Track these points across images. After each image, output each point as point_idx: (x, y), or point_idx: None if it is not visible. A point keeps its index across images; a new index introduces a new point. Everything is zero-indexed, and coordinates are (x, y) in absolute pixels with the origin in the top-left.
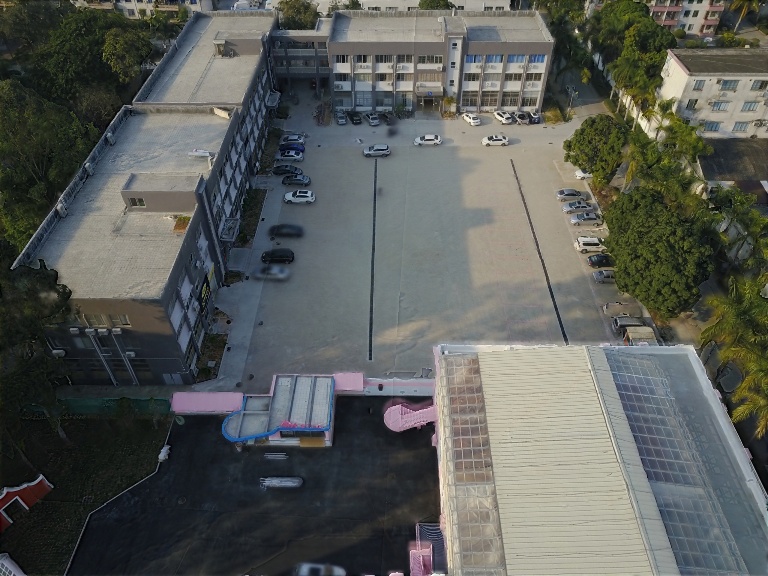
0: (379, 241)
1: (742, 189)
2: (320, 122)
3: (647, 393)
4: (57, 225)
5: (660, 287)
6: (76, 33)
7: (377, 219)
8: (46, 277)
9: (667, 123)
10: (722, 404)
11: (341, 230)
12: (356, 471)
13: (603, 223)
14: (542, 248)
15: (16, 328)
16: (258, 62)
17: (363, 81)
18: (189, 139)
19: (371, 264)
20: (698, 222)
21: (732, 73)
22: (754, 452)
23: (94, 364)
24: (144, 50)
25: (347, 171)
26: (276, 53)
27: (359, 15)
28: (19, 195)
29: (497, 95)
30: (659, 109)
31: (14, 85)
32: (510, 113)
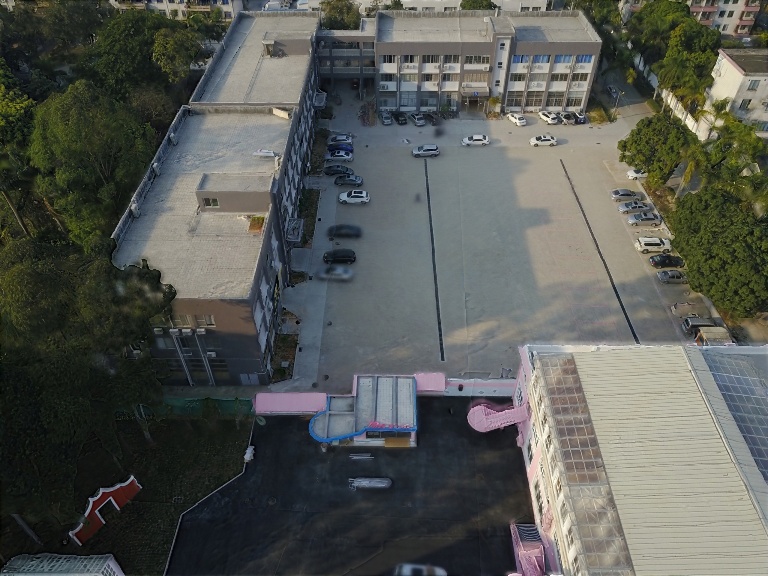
0: (438, 241)
1: None
2: (365, 122)
3: (748, 393)
4: (131, 225)
5: (738, 287)
6: (125, 33)
7: (433, 219)
8: (154, 277)
9: (721, 123)
10: None
11: (399, 230)
12: (444, 472)
13: (661, 223)
14: (602, 248)
15: (131, 328)
16: (309, 62)
17: (409, 81)
18: (251, 139)
19: (433, 264)
20: None
21: None
22: None
23: (172, 364)
24: (193, 50)
25: (398, 171)
26: (321, 53)
27: (402, 15)
28: (86, 195)
29: (542, 95)
30: (713, 109)
31: (88, 85)
32: (555, 113)
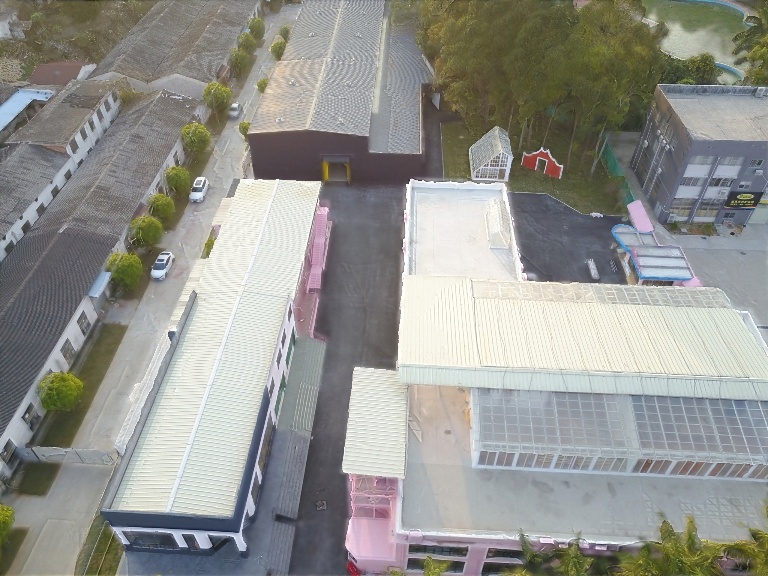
0: None
1: None
2: None
3: (746, 434)
4: (745, 96)
5: None
6: None
7: None
8: (654, 57)
9: None
10: None
11: None
12: None
13: None
14: None
15: (614, 62)
16: None
17: None
18: None
19: None
20: None
21: None
22: None
23: (649, 167)
24: None
25: None
26: None
27: None
28: None
29: None
30: None
31: None
32: None
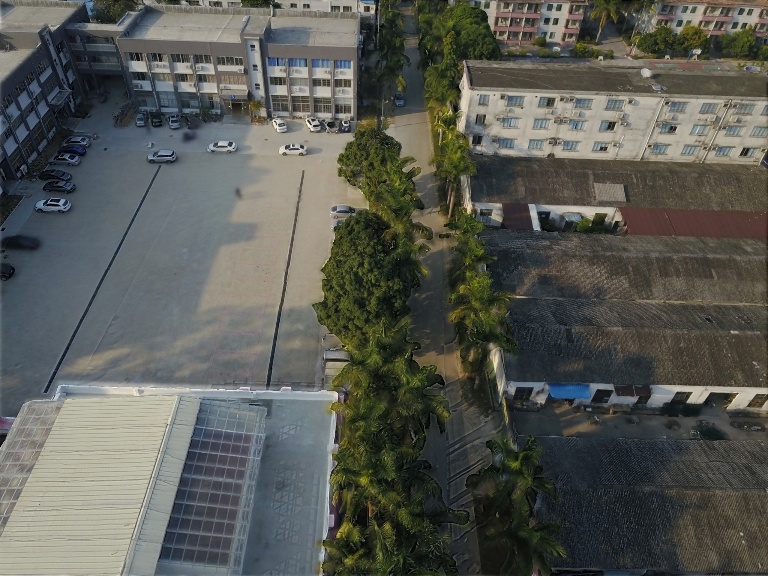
0: (120, 257)
1: (506, 213)
2: (117, 123)
3: (228, 452)
4: None
5: (345, 322)
6: None
7: (129, 232)
8: None
9: None
10: (334, 461)
11: (84, 243)
12: None
13: None
14: (291, 269)
15: None
16: (27, 57)
17: (163, 81)
18: None
19: (99, 283)
20: (394, 253)
21: (515, 89)
22: (336, 520)
23: None
24: None
25: (122, 178)
26: (75, 47)
27: (172, 10)
28: None
29: (309, 101)
30: (443, 124)
31: None
32: (320, 120)
